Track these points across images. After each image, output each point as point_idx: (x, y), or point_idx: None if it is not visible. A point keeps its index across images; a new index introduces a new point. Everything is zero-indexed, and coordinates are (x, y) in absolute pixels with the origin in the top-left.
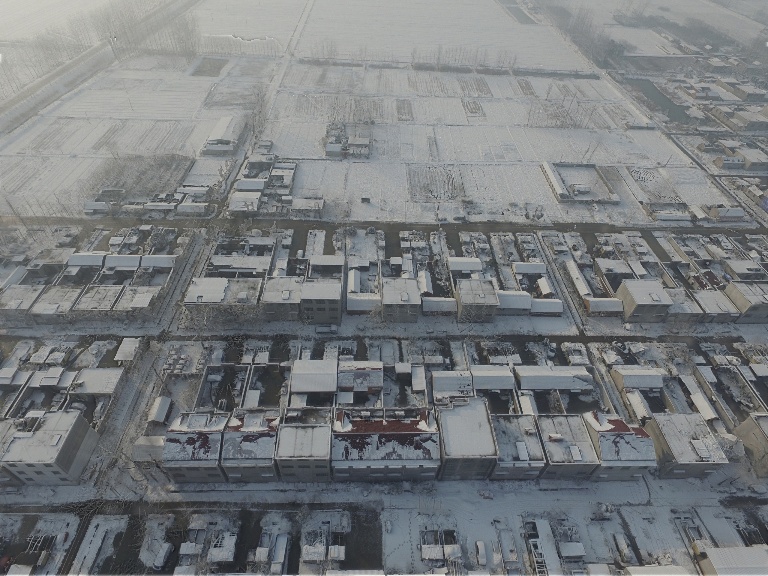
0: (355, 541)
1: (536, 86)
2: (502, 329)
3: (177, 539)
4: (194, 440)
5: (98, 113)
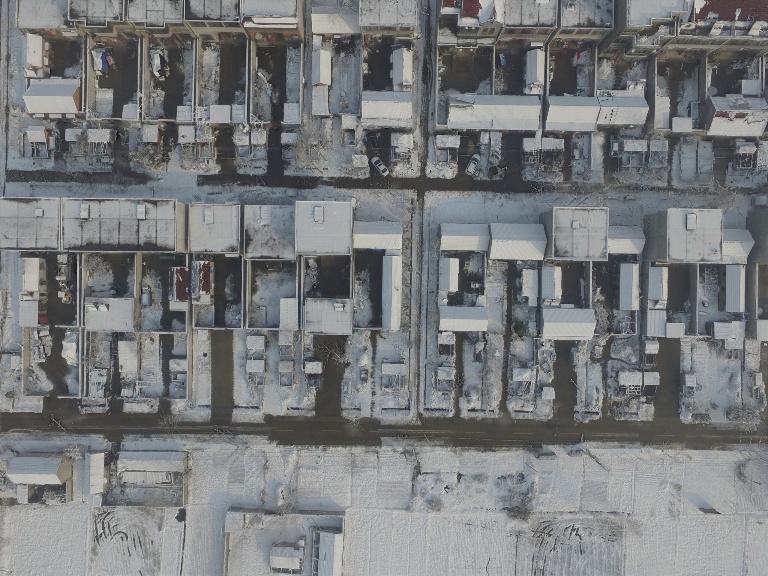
0: None
1: None
2: (529, 203)
3: None
4: None
5: None
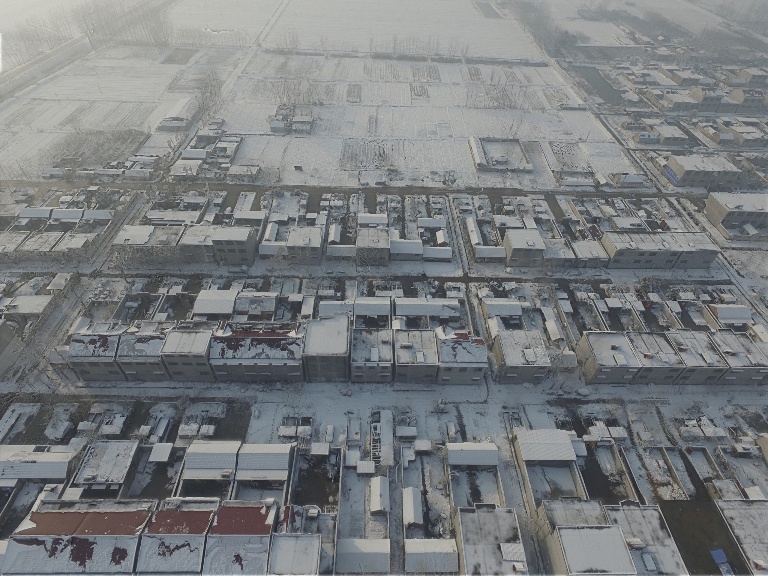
0: (226, 424)
1: (484, 73)
2: (395, 271)
3: (78, 421)
4: (96, 341)
5: (69, 95)
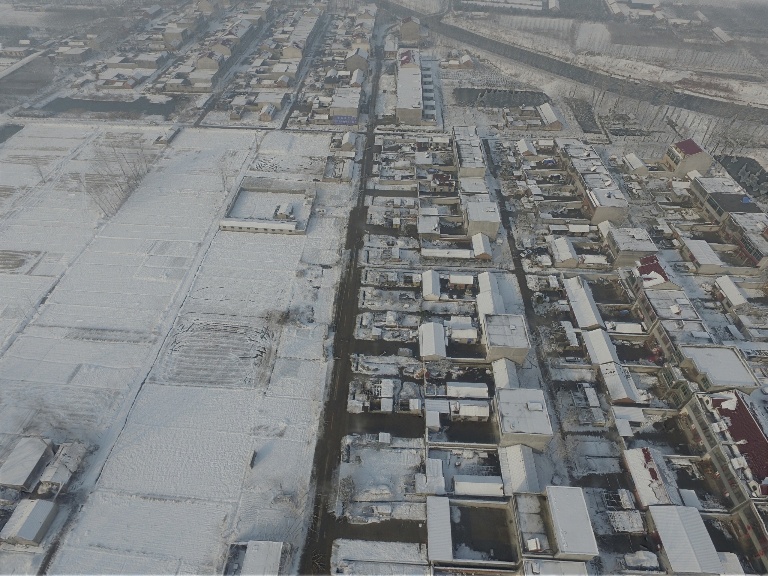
0: None
1: None
2: None
3: None
4: None
5: None
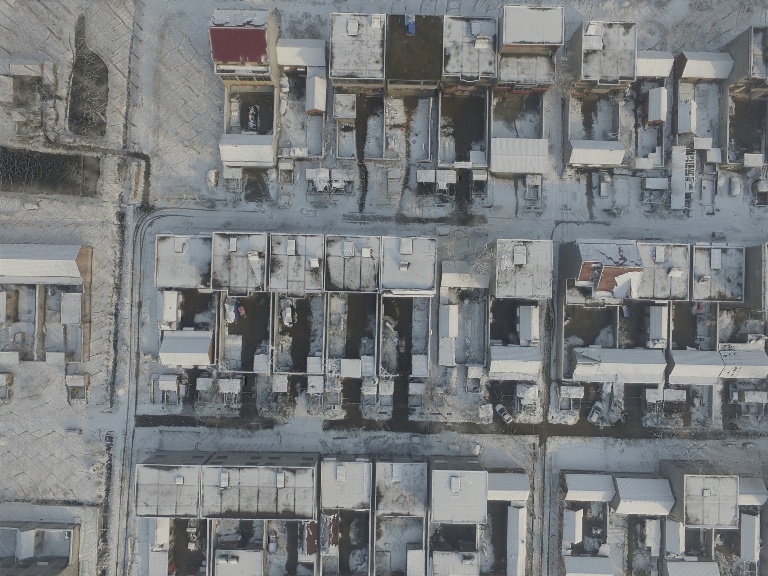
0: None
1: None
2: (649, 449)
3: None
4: None
5: None
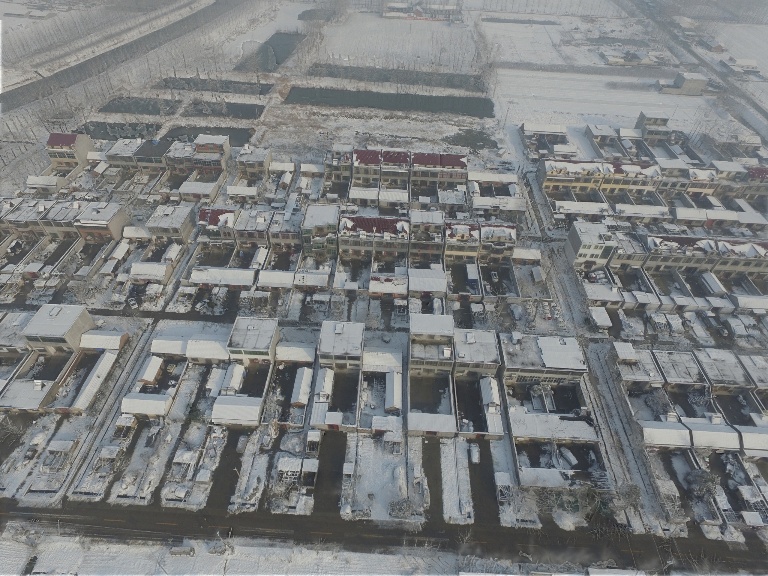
0: None
1: None
2: None
3: None
4: None
5: None
